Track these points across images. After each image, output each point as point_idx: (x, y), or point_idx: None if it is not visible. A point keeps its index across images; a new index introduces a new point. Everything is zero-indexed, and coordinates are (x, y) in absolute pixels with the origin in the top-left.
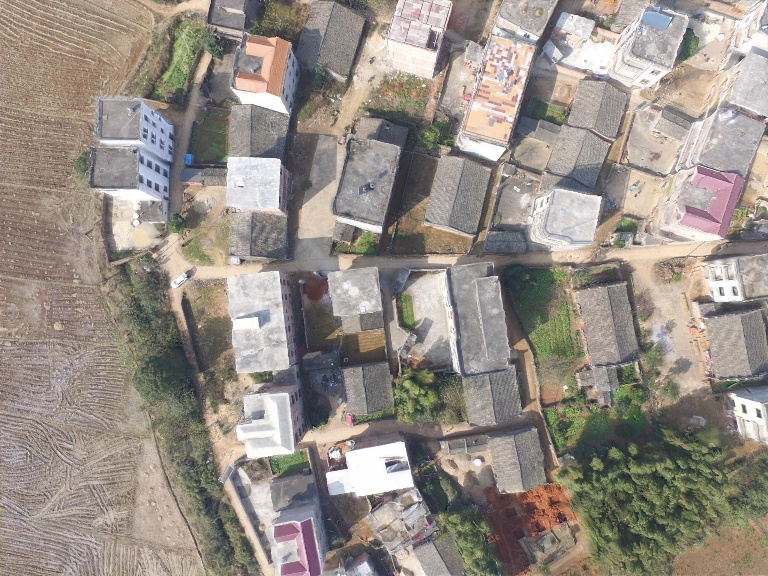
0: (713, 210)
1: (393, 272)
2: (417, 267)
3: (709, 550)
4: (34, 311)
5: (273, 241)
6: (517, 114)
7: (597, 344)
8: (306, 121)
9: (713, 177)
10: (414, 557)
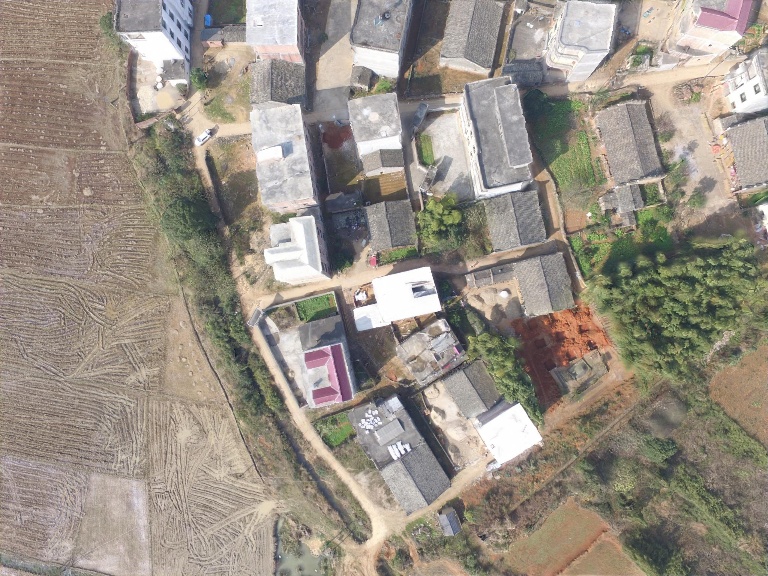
0: (729, 9)
1: (411, 115)
2: (434, 108)
3: (746, 370)
4: (64, 178)
5: (292, 88)
6: None
7: (619, 163)
8: None
9: None
10: (444, 396)
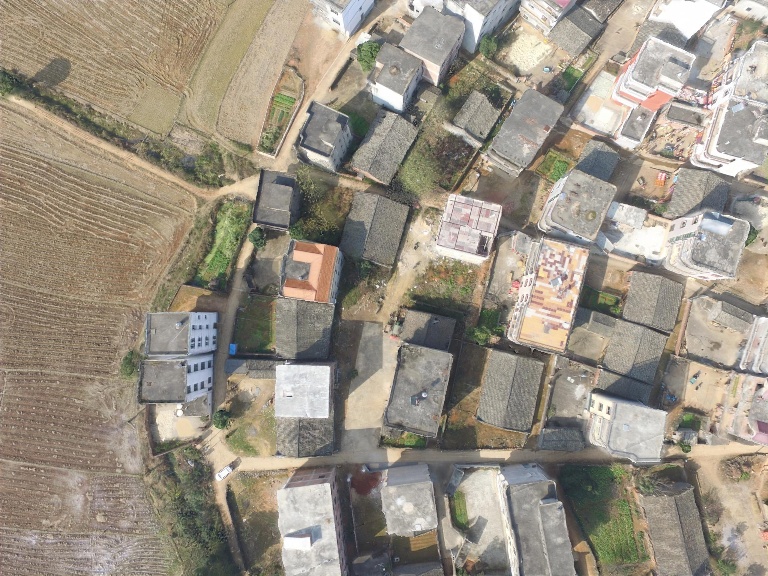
0: None
1: (444, 466)
2: (469, 461)
3: None
4: (77, 502)
5: (320, 438)
6: (573, 320)
7: (665, 555)
8: (351, 307)
9: None
10: None
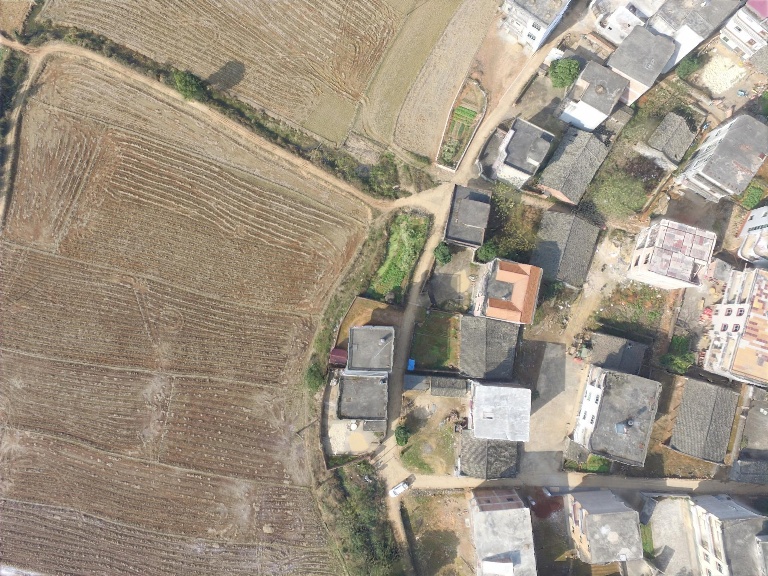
0: None
1: (629, 493)
2: (655, 490)
3: None
4: (243, 512)
5: (506, 460)
6: None
7: None
8: (533, 328)
9: None
10: None
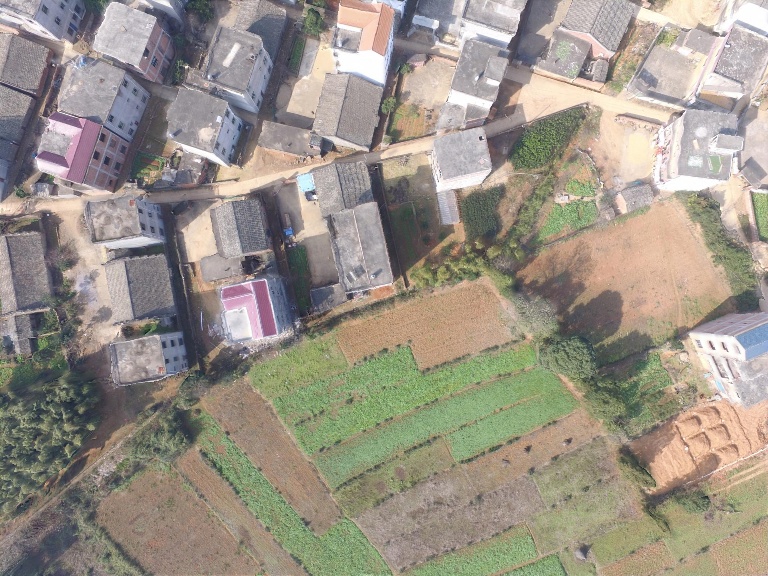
0: (68, 155)
1: None
2: None
3: (133, 496)
4: None
5: None
6: None
7: (4, 294)
8: None
9: (63, 122)
10: None
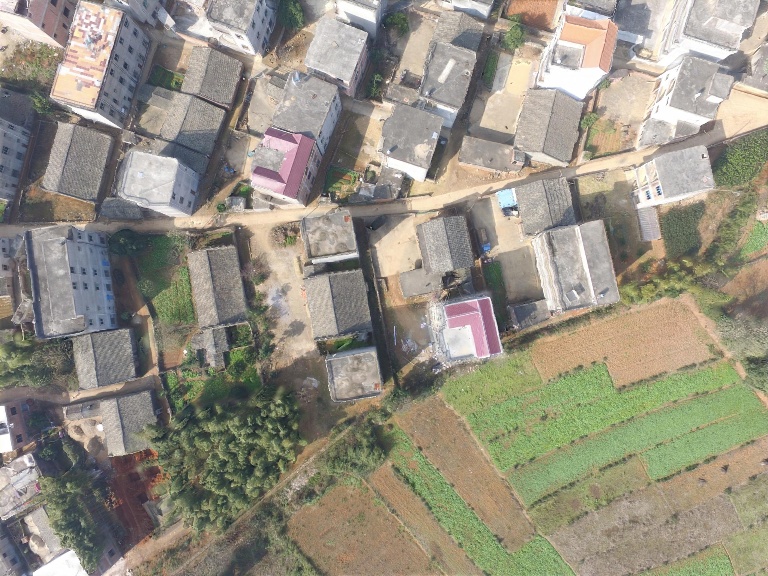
0: (282, 171)
1: None
2: None
3: (324, 510)
4: None
5: None
6: (105, 79)
7: (202, 307)
8: None
9: (279, 138)
10: None
